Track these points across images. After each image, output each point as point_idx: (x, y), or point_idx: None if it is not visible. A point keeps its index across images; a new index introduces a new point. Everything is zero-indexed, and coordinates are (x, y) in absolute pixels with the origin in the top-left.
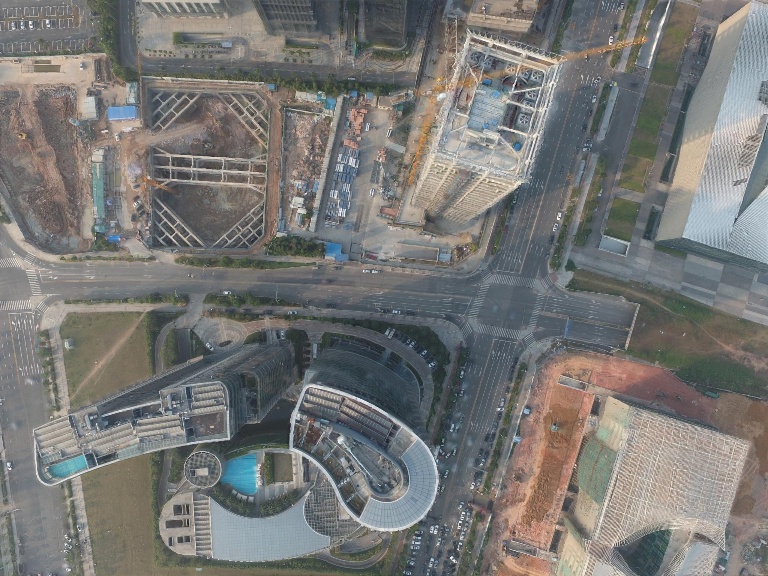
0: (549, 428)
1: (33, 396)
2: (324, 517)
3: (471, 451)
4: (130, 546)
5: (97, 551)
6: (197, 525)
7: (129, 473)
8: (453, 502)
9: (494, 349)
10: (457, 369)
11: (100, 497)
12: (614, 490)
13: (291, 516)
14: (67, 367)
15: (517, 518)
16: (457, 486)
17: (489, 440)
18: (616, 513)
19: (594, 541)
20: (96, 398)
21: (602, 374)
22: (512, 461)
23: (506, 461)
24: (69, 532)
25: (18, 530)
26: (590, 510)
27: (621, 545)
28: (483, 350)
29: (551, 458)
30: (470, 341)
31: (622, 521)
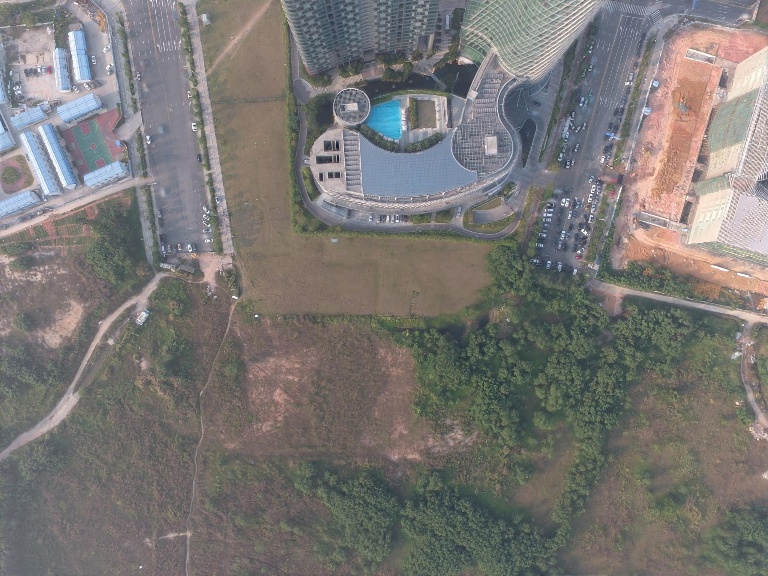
0: (677, 102)
1: (170, 72)
2: (471, 153)
3: (600, 126)
4: (267, 218)
5: (235, 223)
6: (347, 160)
7: (265, 146)
8: (583, 176)
9: (622, 25)
10: (586, 42)
11: (237, 170)
12: (757, 125)
13: (439, 151)
14: (203, 43)
15: (647, 192)
16: (587, 160)
17: (618, 115)
18: (759, 147)
19: (738, 175)
20: (232, 72)
21: (729, 48)
22: (641, 135)
23: (636, 134)
24: (207, 205)
25: (157, 203)
26: (729, 157)
27: (765, 178)
28: (611, 26)
29: (680, 131)
30: (598, 17)
31: (766, 154)
